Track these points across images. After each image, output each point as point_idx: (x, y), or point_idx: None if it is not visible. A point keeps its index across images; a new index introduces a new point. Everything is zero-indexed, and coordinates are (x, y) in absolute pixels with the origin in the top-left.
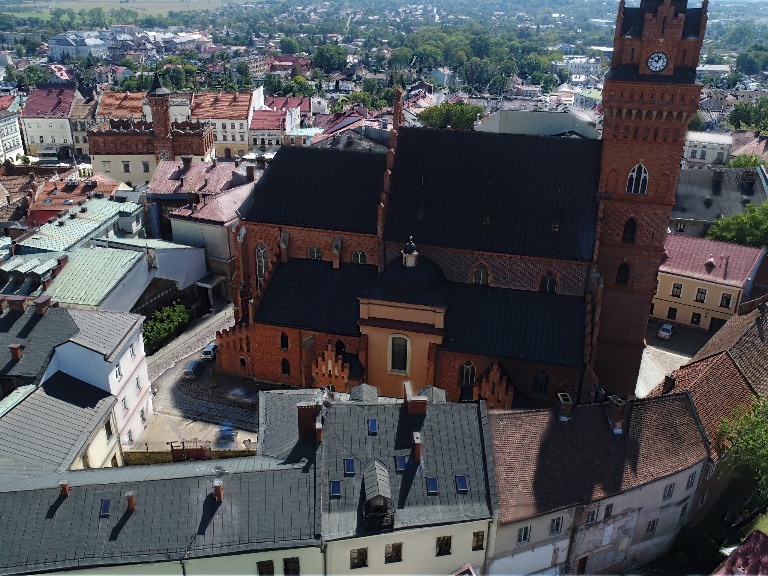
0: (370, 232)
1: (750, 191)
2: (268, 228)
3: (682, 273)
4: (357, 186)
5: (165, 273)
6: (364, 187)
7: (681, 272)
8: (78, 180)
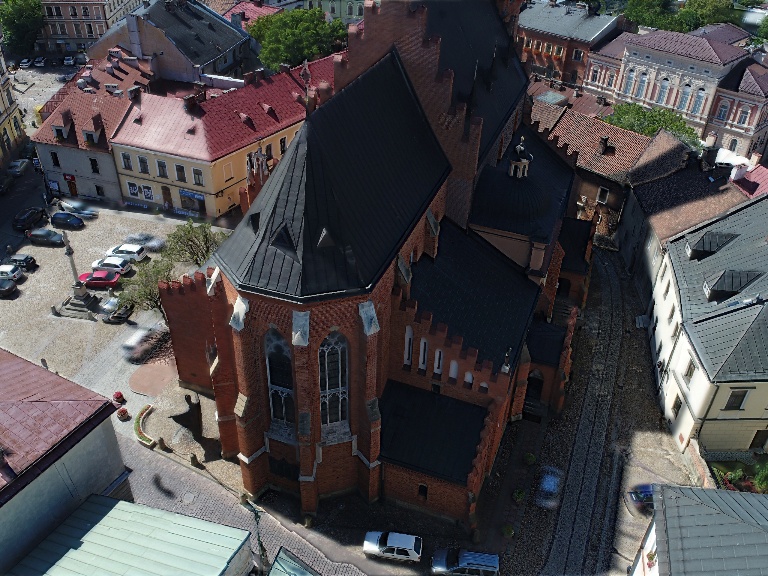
0: (446, 176)
1: (197, 15)
2: (386, 272)
3: None
4: (401, 124)
5: None
6: (405, 120)
7: None
8: None
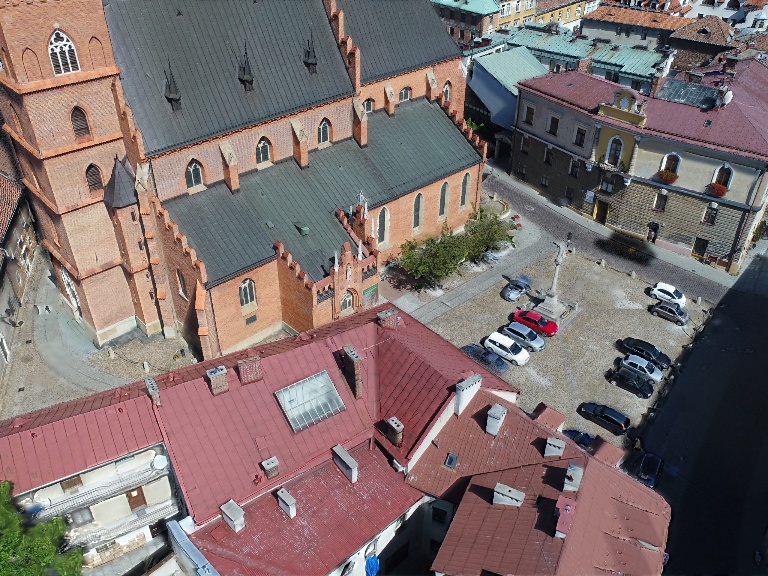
0: None
1: None
2: None
3: (75, 401)
4: None
5: (479, 90)
6: None
7: (77, 401)
8: (762, 58)
